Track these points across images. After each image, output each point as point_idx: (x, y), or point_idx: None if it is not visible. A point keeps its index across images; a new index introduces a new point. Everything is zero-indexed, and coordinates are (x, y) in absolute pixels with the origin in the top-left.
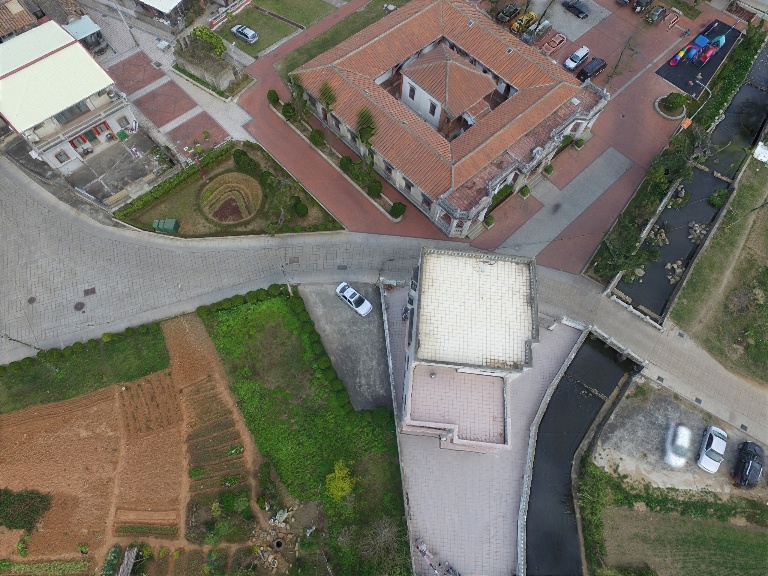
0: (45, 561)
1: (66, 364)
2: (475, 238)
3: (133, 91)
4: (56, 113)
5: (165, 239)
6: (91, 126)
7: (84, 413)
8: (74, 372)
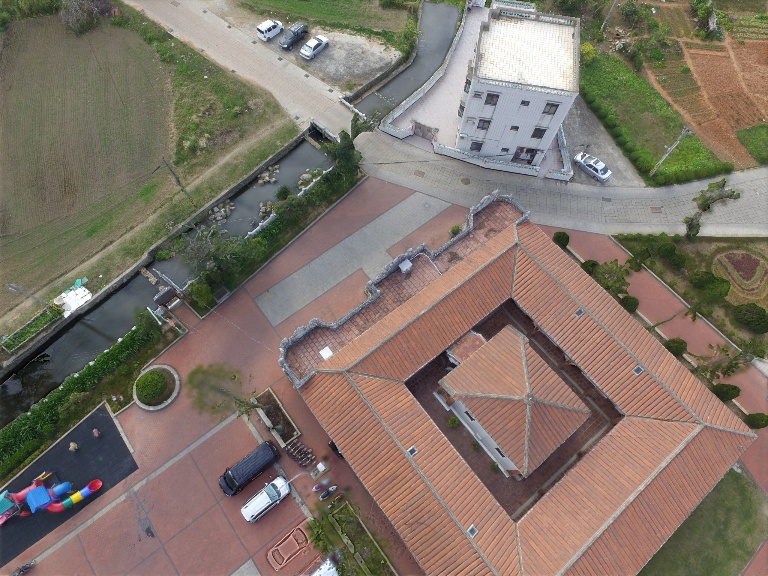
0: (761, 39)
1: None
2: None
3: None
4: None
5: None
6: None
7: None
8: None
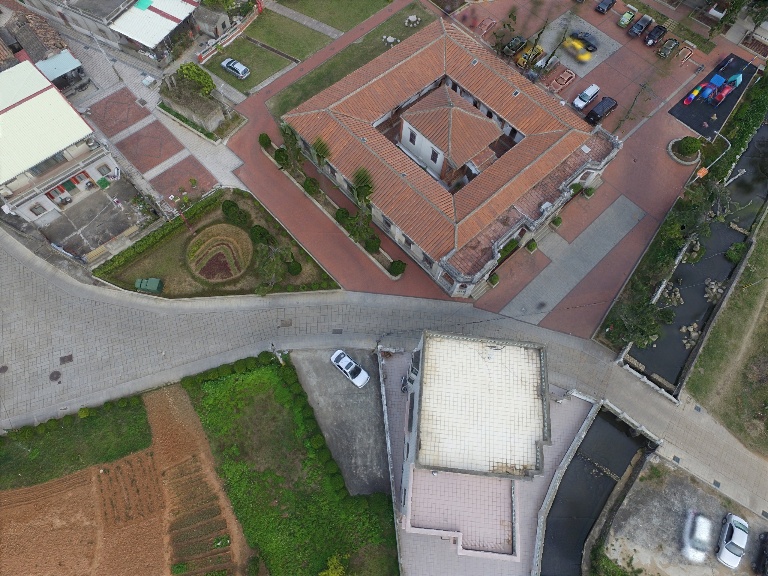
0: None
1: (39, 443)
2: (479, 298)
3: (116, 132)
4: (29, 167)
5: (148, 299)
6: (69, 177)
7: (58, 500)
8: (48, 452)
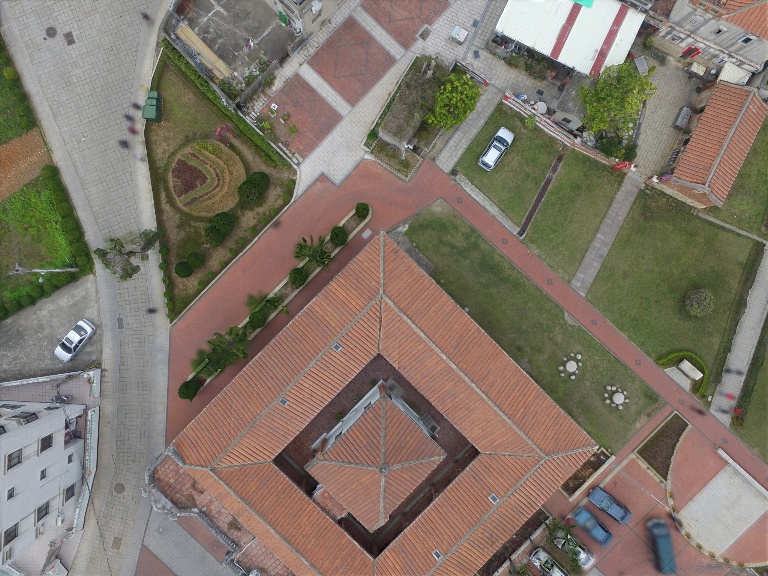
0: None
1: None
2: None
3: (371, 12)
4: None
5: None
6: None
7: None
8: None
